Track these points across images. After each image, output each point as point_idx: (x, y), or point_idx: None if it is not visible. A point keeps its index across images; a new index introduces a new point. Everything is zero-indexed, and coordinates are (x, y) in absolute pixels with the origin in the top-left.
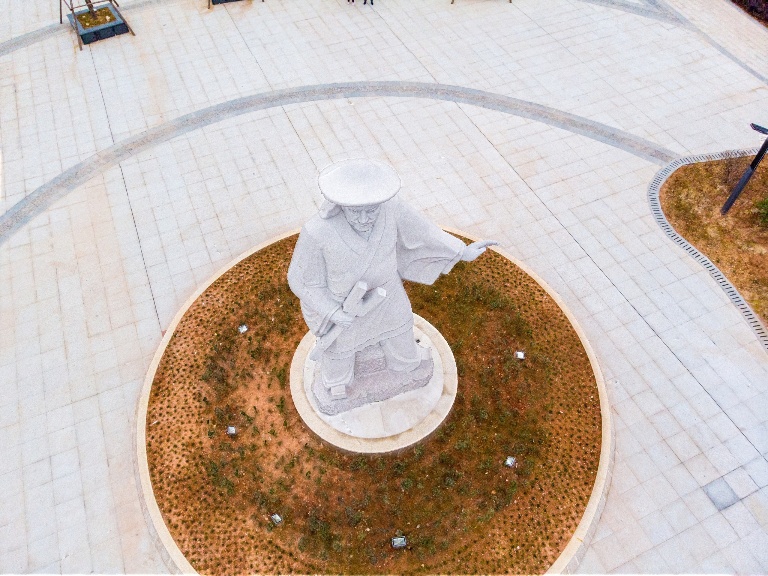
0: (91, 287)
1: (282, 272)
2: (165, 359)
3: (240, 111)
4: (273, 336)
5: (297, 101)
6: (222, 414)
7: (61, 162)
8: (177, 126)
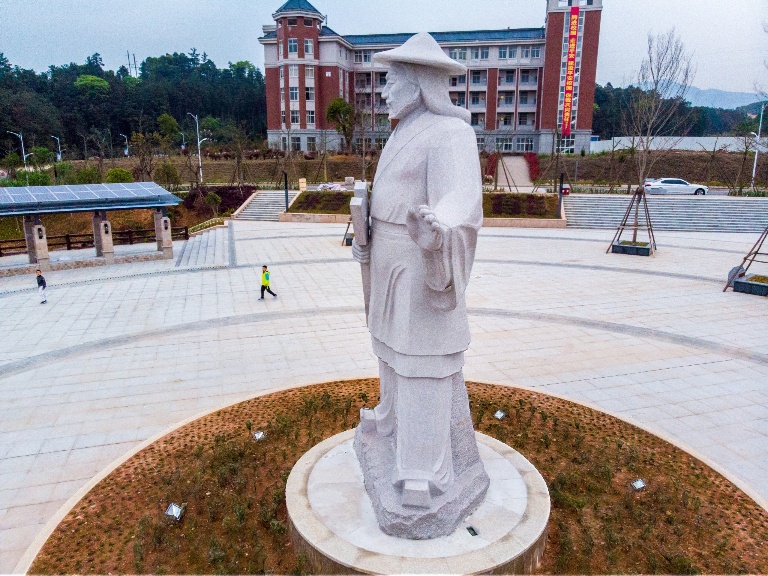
0: (549, 359)
1: (606, 443)
2: None
3: None
4: (493, 435)
5: None
6: None
7: (709, 335)
8: None
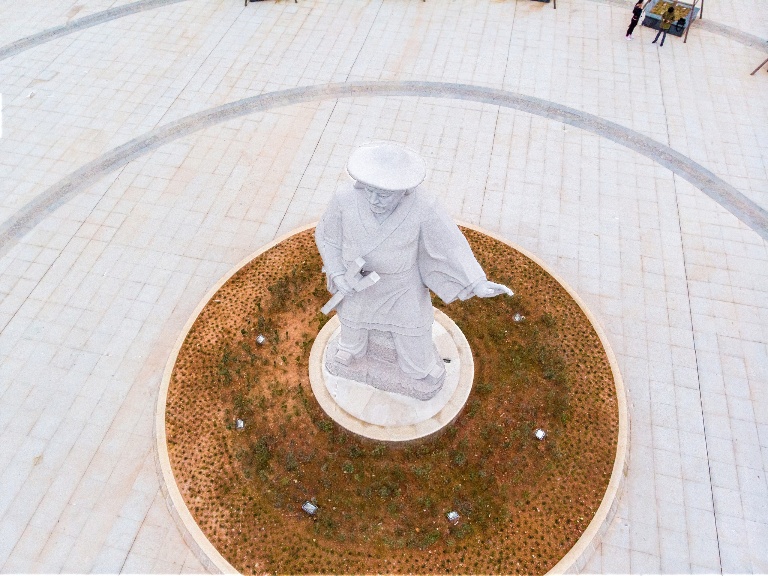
0: (253, 181)
1: None
2: (257, 260)
3: (461, 96)
4: None
5: (516, 107)
6: (264, 323)
7: (300, 79)
8: (402, 87)
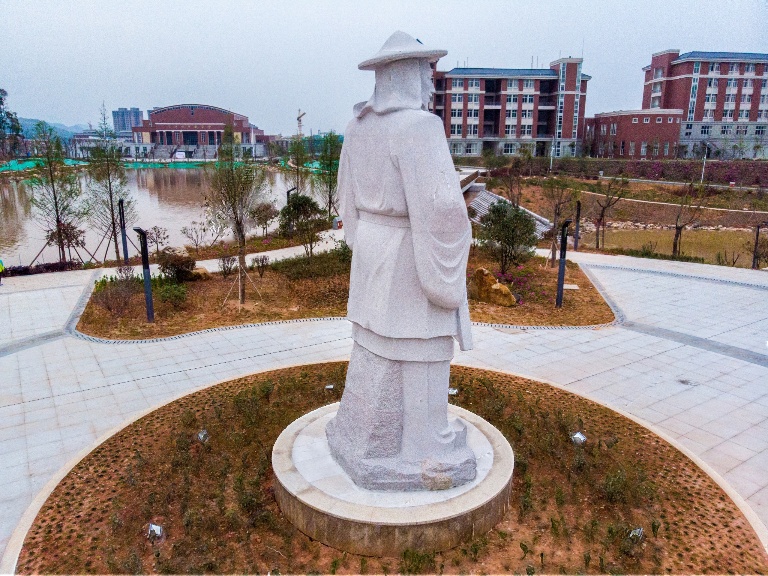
0: None
1: None
2: None
3: None
4: None
5: None
6: None
7: None
8: None
